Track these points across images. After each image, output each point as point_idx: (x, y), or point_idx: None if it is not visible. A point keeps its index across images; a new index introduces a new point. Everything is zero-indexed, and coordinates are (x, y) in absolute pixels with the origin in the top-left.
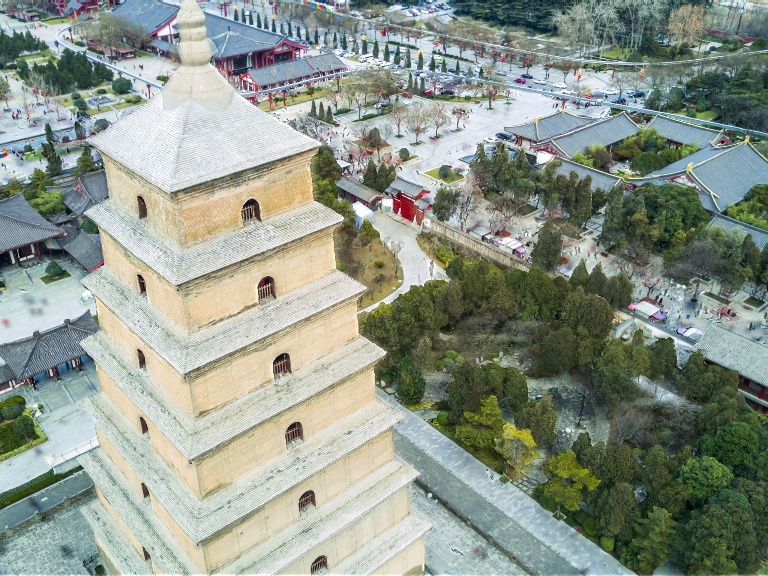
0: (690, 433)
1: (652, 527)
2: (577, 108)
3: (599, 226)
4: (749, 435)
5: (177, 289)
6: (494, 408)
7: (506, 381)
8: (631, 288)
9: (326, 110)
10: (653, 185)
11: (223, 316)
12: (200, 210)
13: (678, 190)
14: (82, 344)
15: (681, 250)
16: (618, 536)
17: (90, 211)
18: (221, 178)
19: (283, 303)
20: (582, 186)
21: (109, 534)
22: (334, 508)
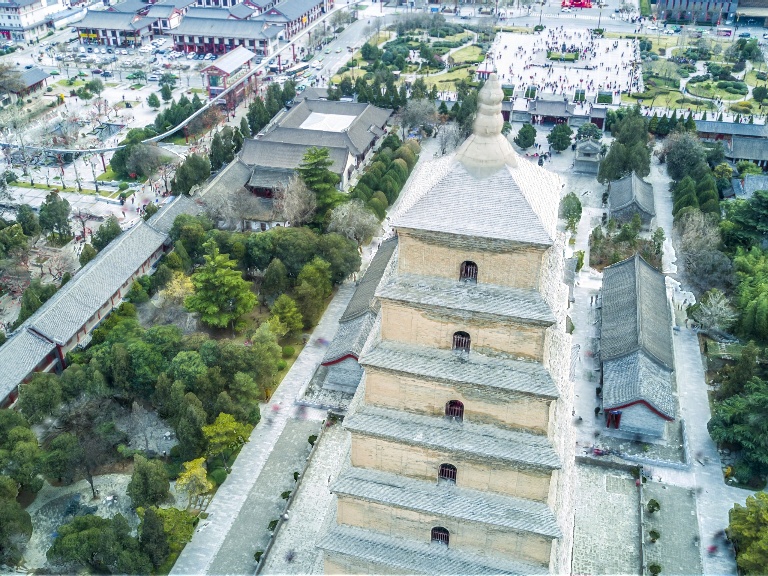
0: None
1: None
2: None
3: None
4: None
5: None
6: None
7: None
8: None
9: None
10: None
11: None
12: None
13: None
14: None
15: None
16: None
17: None
18: None
19: None
20: None
21: None
22: None
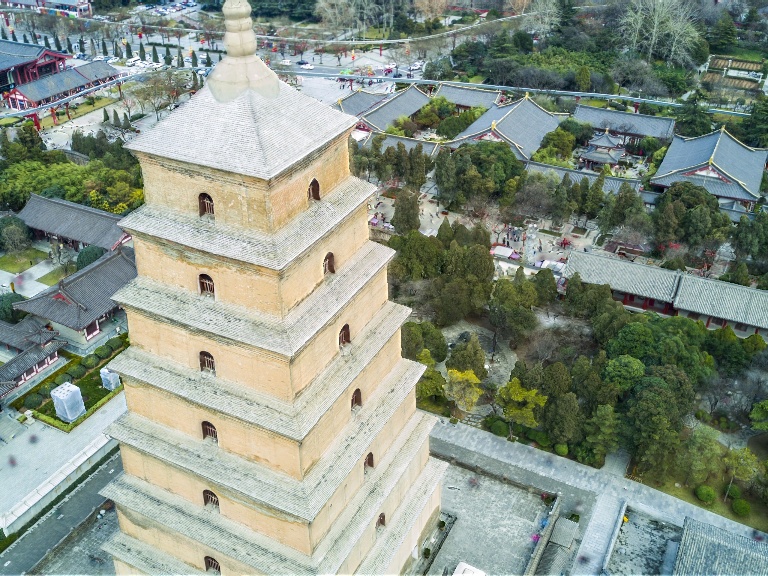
0: (590, 343)
1: (602, 422)
2: (362, 87)
3: (429, 189)
4: (645, 331)
5: (278, 274)
6: (429, 360)
7: (425, 335)
8: (489, 235)
9: (122, 117)
10: (470, 144)
11: (303, 296)
12: (282, 194)
13: (494, 145)
14: (112, 366)
15: (517, 196)
16: (571, 440)
17: (125, 221)
18: (299, 160)
19: (341, 276)
20: (415, 154)
21: (149, 560)
22: (387, 465)
